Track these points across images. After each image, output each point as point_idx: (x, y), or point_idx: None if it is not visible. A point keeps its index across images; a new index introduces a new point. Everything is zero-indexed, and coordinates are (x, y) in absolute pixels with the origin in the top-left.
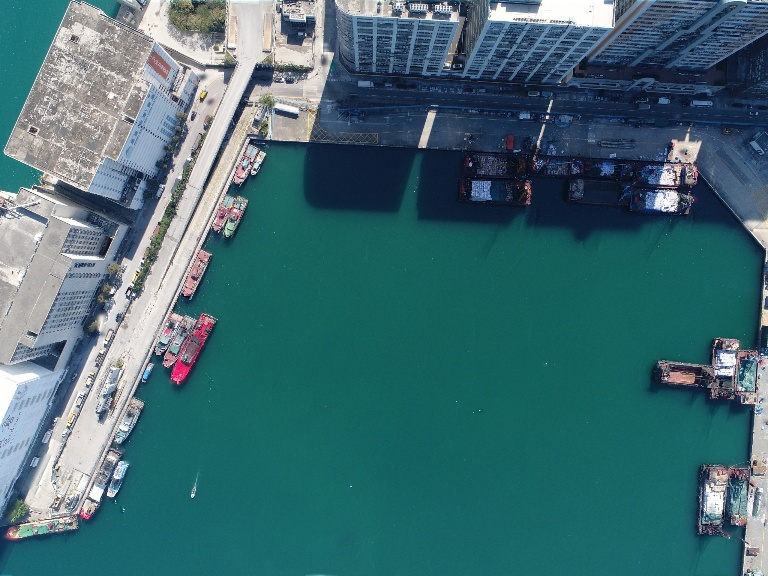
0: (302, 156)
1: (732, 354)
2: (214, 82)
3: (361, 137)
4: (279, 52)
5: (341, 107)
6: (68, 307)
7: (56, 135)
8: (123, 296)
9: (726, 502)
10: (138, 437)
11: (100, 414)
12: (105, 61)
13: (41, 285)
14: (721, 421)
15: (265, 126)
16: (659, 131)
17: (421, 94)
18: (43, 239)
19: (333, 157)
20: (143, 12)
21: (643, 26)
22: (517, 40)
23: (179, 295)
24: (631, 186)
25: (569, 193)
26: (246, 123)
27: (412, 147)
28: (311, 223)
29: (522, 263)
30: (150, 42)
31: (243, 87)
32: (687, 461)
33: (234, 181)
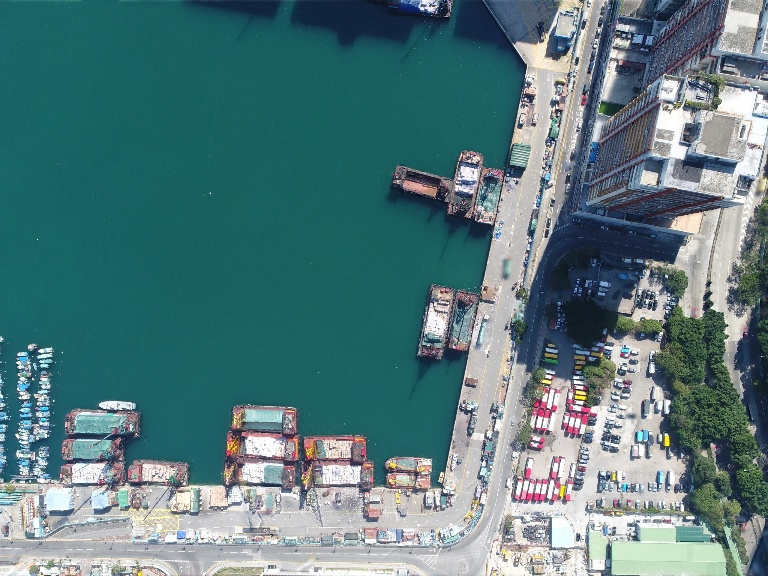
0: None
1: (474, 168)
2: None
3: None
4: None
5: None
6: None
7: None
8: None
9: (451, 326)
10: None
11: None
12: None
13: None
14: (458, 242)
15: None
16: None
17: None
18: None
19: None
20: None
21: None
22: None
23: None
24: None
25: None
26: None
27: None
28: None
29: (273, 49)
30: None
31: None
32: (420, 280)
33: None
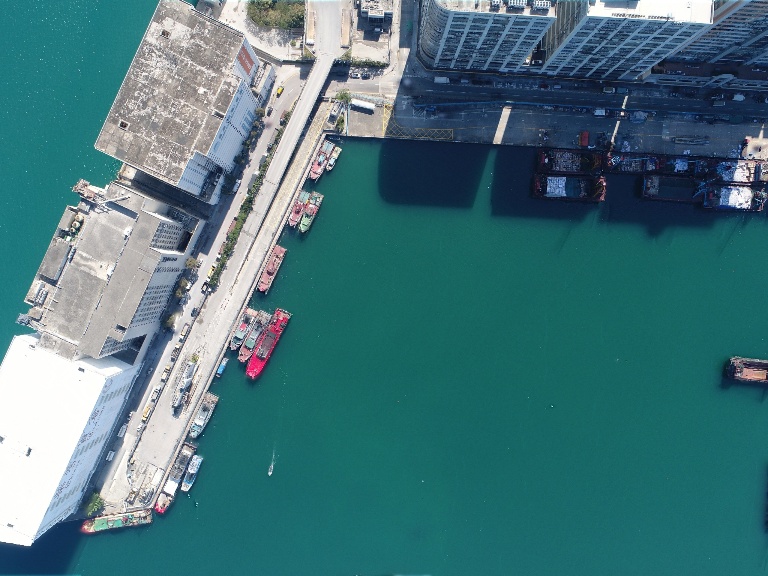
0: (377, 152)
1: None
2: (291, 78)
3: (436, 133)
4: (355, 48)
5: (416, 103)
6: (152, 301)
7: (146, 130)
8: (198, 291)
9: None
10: (212, 431)
11: (175, 408)
12: (195, 56)
13: (130, 279)
14: None
15: (341, 122)
16: (733, 128)
17: (496, 90)
18: (133, 233)
19: (408, 153)
20: (221, 8)
21: (735, 22)
22: (609, 36)
23: (254, 290)
24: (705, 182)
25: (643, 189)
26: (322, 119)
27: (487, 143)
28: (385, 219)
29: (595, 259)
30: (240, 37)
31: (321, 83)
32: (757, 457)
33: (310, 176)
